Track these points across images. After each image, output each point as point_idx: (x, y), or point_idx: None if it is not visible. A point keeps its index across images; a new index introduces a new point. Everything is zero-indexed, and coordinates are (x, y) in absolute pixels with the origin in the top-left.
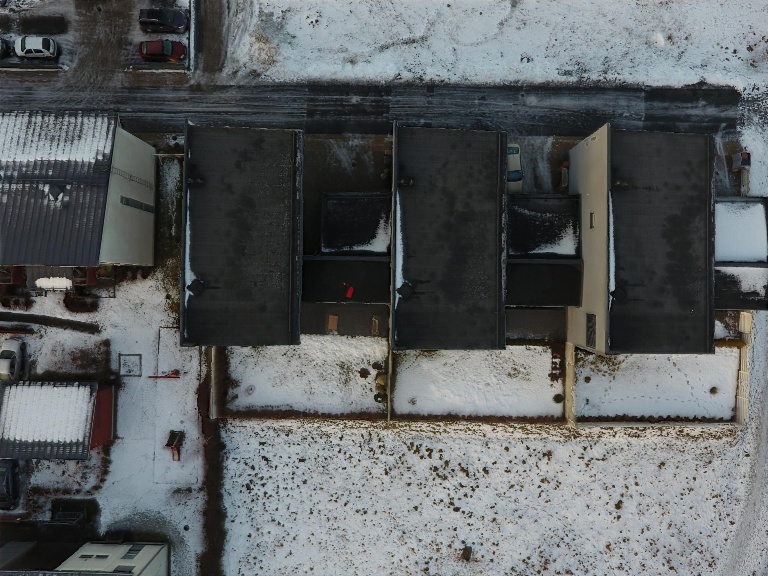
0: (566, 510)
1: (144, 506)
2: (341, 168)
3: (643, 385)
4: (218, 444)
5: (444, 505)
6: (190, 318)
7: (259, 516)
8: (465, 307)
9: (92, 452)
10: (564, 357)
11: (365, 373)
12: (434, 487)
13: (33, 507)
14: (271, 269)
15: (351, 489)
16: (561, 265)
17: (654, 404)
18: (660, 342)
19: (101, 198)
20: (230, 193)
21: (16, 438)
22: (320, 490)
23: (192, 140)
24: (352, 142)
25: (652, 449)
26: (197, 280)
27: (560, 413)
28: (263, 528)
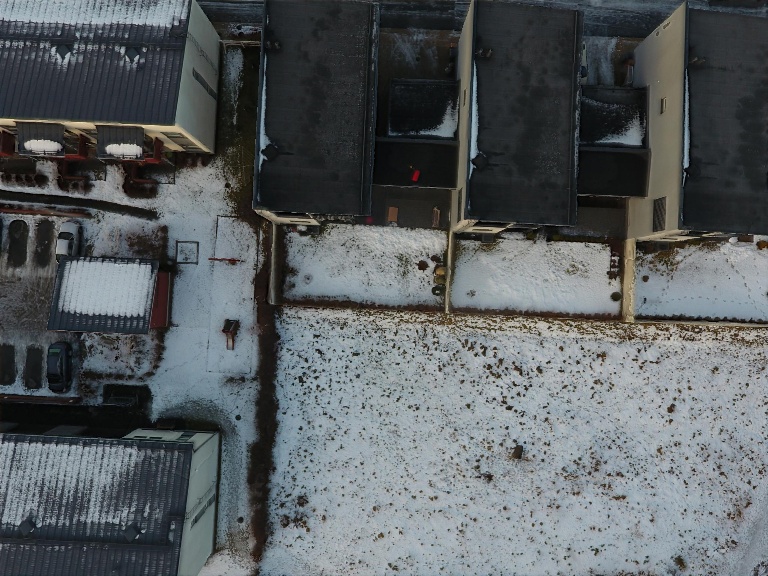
0: (618, 412)
1: (196, 394)
2: (405, 62)
3: (701, 286)
4: (273, 335)
5: (496, 403)
6: (263, 182)
7: (311, 409)
8: (538, 181)
9: (146, 338)
10: (623, 255)
11: (424, 265)
12: (487, 385)
13: (85, 392)
14: (345, 138)
15: (404, 385)
16: (628, 154)
17: (711, 305)
18: (732, 221)
19: (177, 61)
20: (307, 61)
21: (76, 311)
22: (373, 385)
23: (271, 6)
24: (417, 37)
25: (706, 353)
26: (271, 145)
27: (617, 311)
28: (314, 421)
